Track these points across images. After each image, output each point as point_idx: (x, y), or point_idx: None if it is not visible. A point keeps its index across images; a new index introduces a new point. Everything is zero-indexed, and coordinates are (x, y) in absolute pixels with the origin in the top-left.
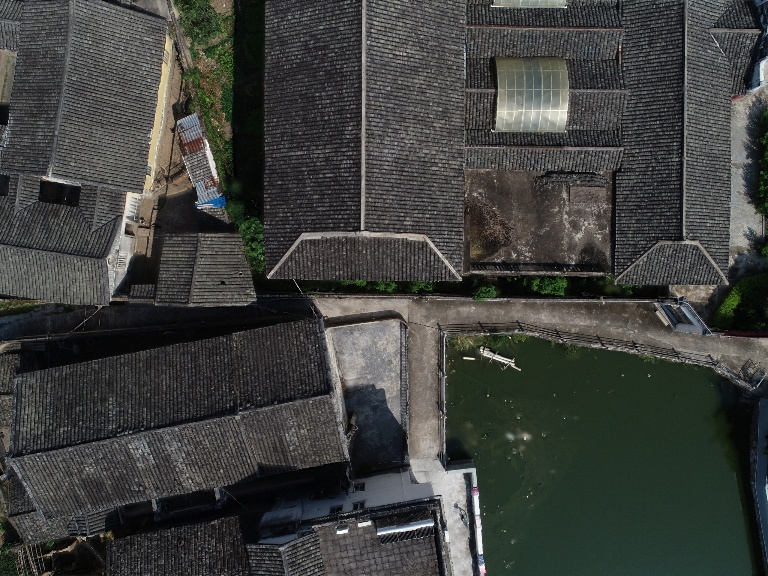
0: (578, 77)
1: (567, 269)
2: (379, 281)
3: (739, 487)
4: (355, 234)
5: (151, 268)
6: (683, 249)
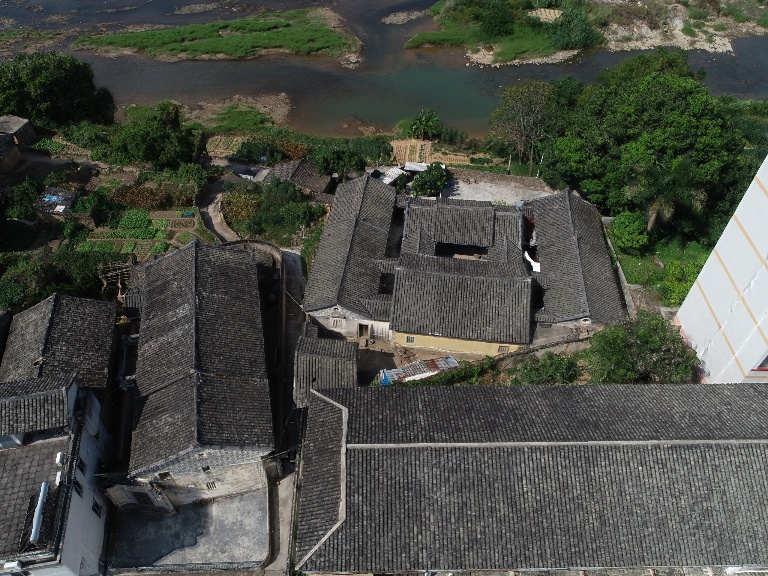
0: None
1: None
2: None
3: None
4: None
5: None
6: None
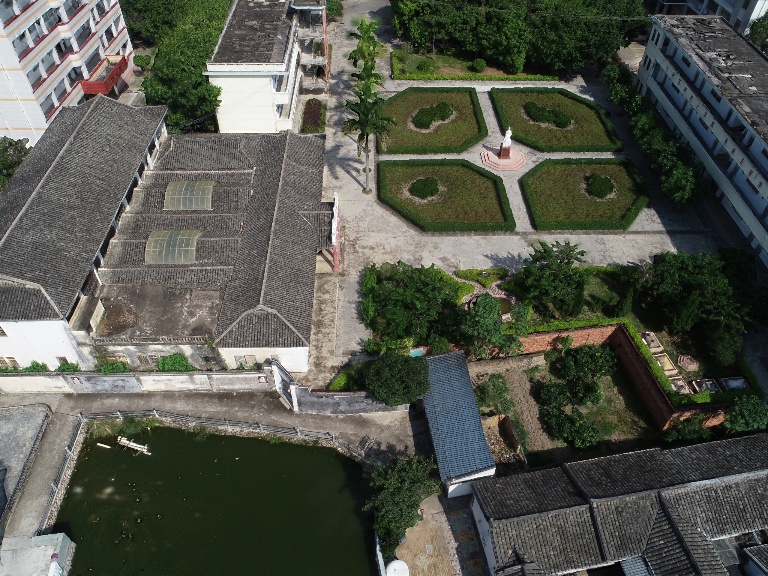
0: None
1: None
2: (30, 366)
3: None
4: None
5: None
6: (266, 318)
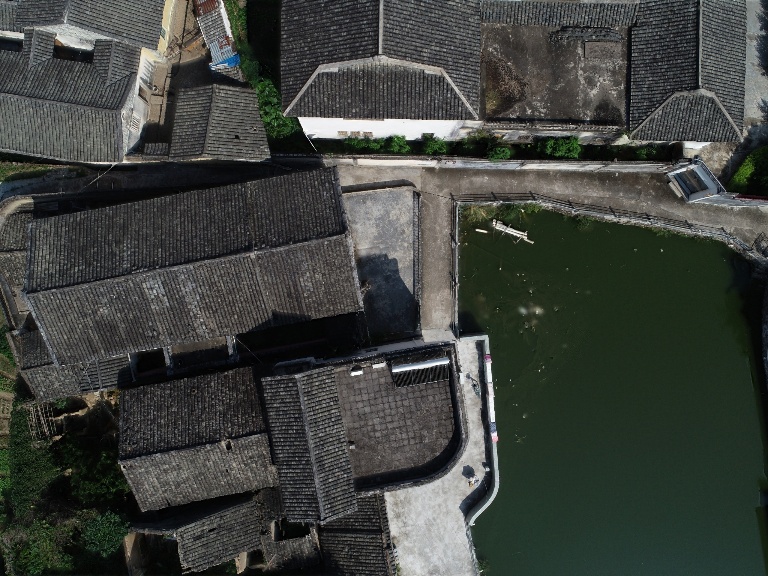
0: None
1: None
2: (393, 143)
3: (751, 364)
4: (373, 59)
5: (164, 136)
6: (698, 102)
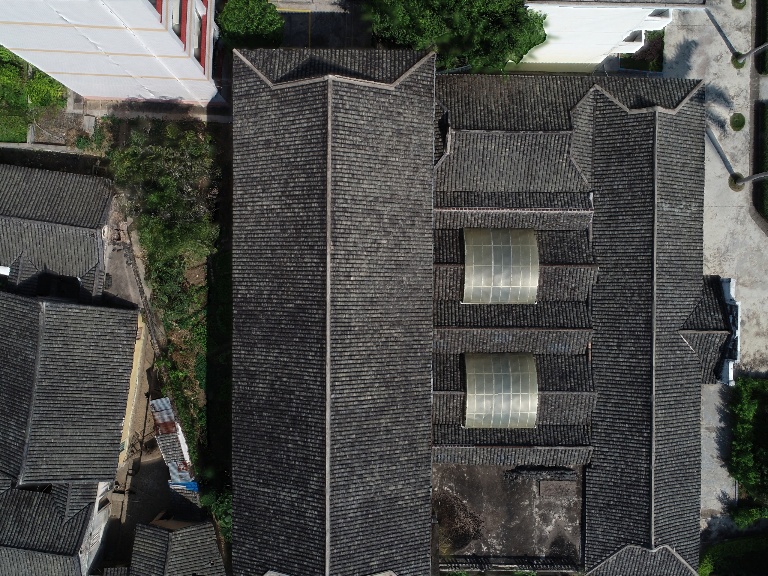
0: (548, 376)
1: (537, 561)
2: None
3: None
4: None
5: (125, 533)
6: None
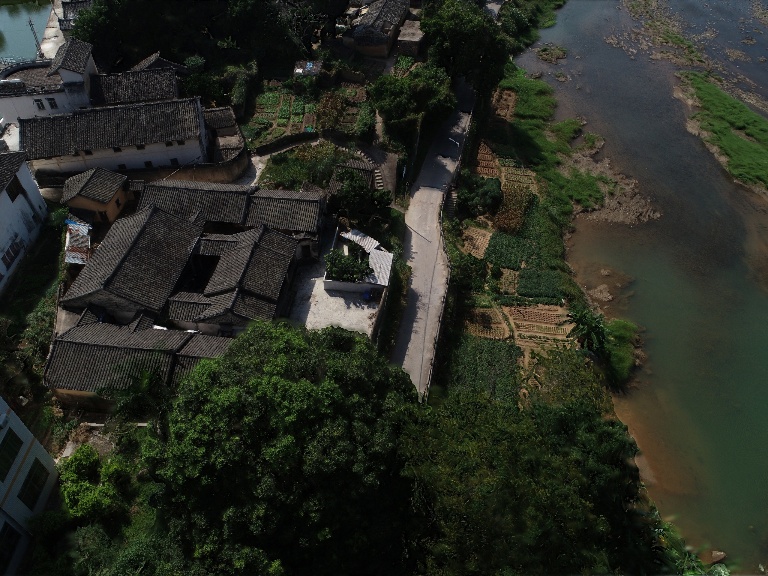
0: None
1: None
2: None
3: None
4: None
5: None
6: None
